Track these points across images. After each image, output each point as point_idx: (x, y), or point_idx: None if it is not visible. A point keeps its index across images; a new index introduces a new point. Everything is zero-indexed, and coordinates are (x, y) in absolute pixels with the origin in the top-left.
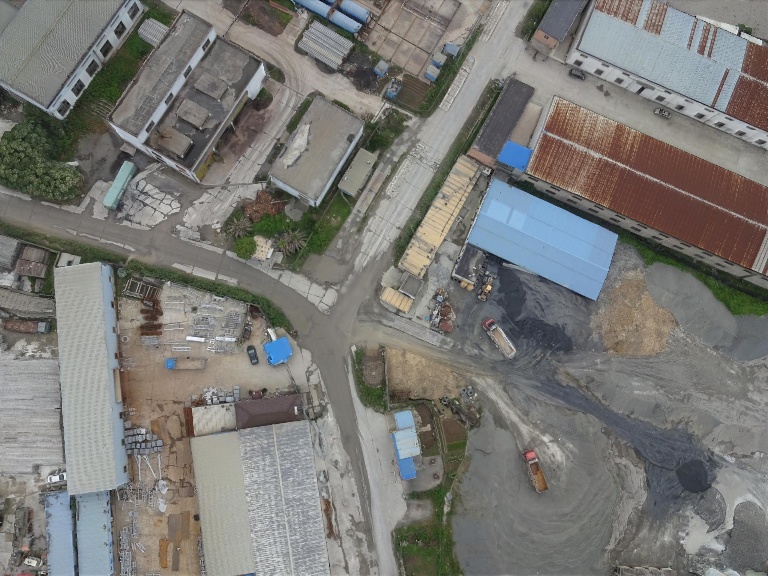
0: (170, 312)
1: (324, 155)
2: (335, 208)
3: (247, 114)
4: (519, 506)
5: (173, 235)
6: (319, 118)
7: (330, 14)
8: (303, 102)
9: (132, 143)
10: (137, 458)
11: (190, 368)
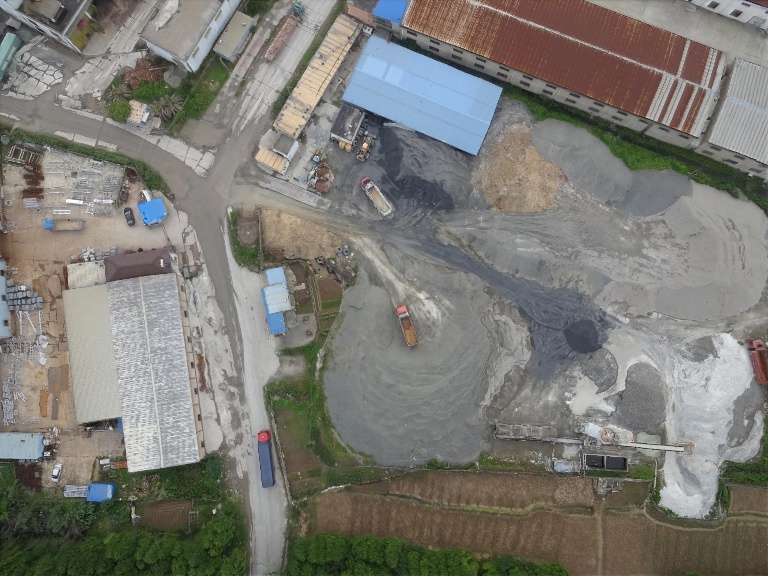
0: (51, 177)
1: (195, 16)
2: (213, 73)
3: None
4: (387, 358)
5: (55, 104)
6: None
7: None
8: None
9: (13, 15)
10: (18, 314)
11: (69, 229)
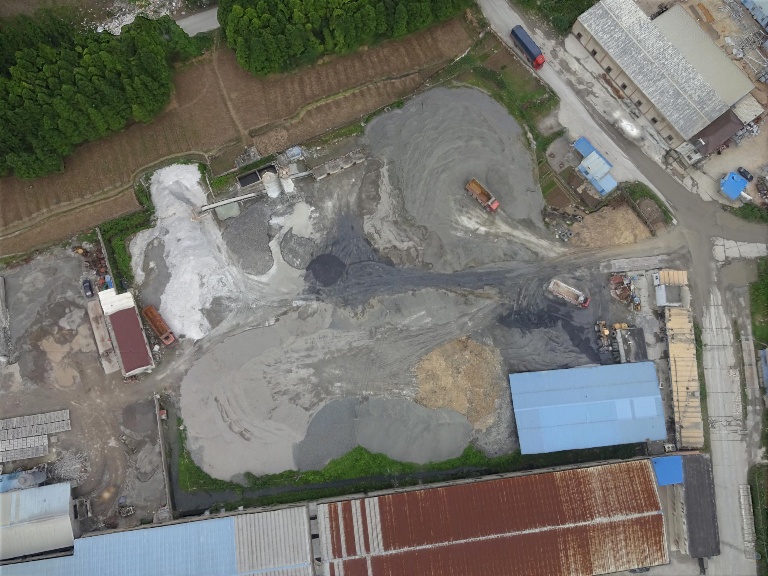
0: None
1: None
2: (767, 331)
3: None
4: (485, 160)
5: None
6: None
7: None
8: None
9: None
10: None
11: None
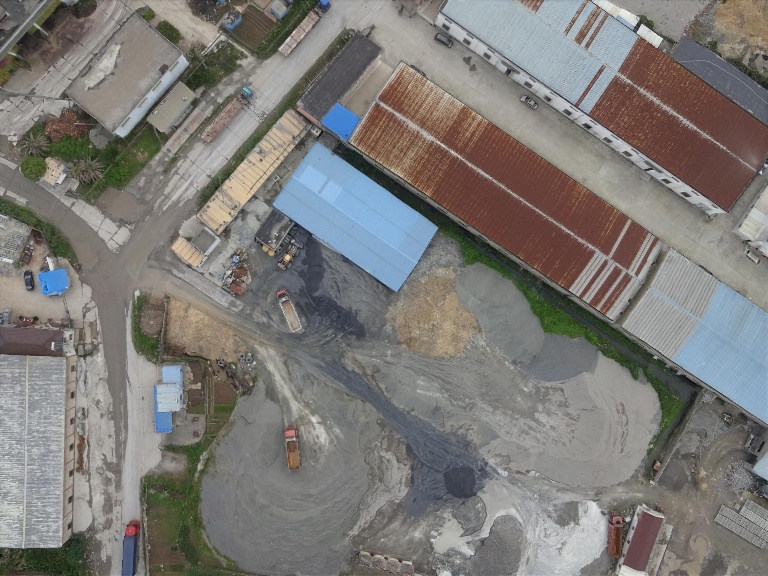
0: None
1: (131, 83)
2: (144, 142)
3: (65, 20)
4: (266, 479)
5: None
6: (132, 40)
7: None
8: (129, 17)
9: None
10: None
11: None
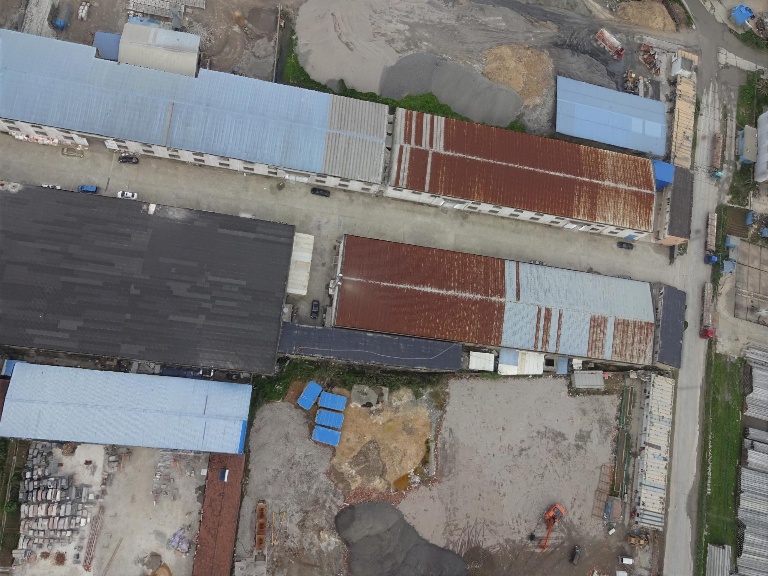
0: None
1: None
2: (747, 120)
3: None
4: None
5: None
6: None
7: None
8: None
9: None
10: None
11: None
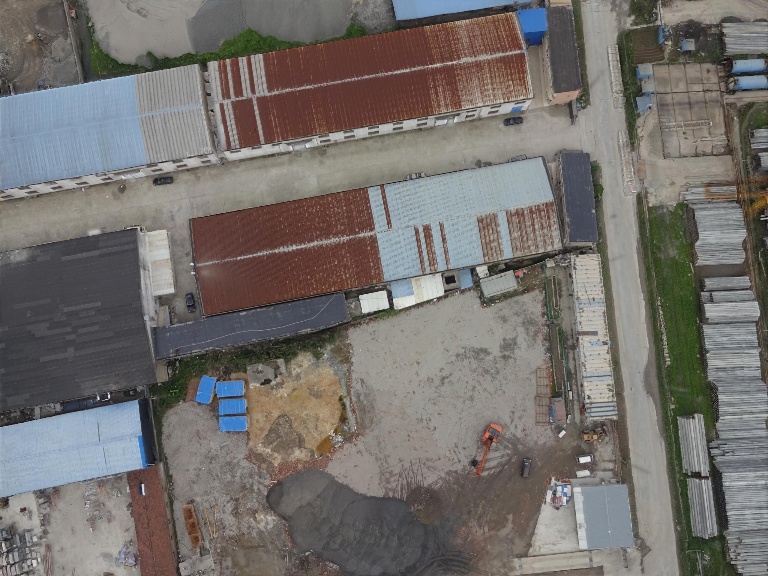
0: None
1: None
2: None
3: None
4: None
5: None
6: None
7: (766, 59)
8: None
9: None
10: None
11: None
